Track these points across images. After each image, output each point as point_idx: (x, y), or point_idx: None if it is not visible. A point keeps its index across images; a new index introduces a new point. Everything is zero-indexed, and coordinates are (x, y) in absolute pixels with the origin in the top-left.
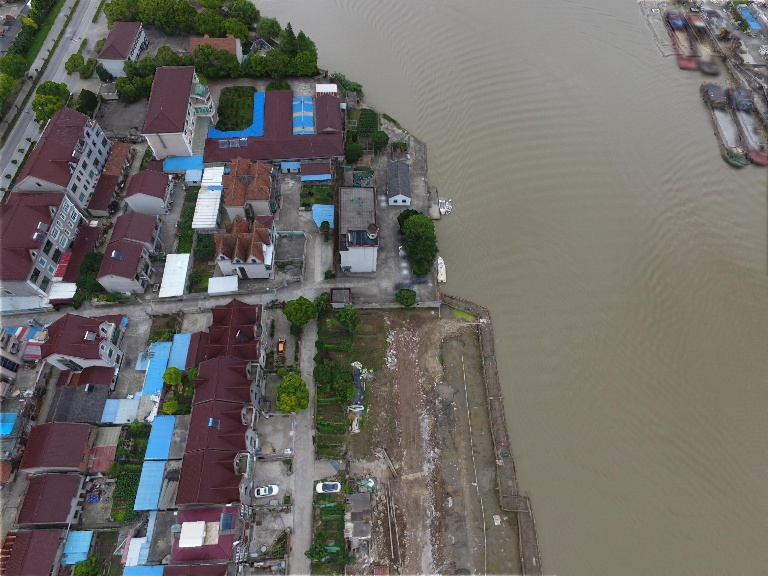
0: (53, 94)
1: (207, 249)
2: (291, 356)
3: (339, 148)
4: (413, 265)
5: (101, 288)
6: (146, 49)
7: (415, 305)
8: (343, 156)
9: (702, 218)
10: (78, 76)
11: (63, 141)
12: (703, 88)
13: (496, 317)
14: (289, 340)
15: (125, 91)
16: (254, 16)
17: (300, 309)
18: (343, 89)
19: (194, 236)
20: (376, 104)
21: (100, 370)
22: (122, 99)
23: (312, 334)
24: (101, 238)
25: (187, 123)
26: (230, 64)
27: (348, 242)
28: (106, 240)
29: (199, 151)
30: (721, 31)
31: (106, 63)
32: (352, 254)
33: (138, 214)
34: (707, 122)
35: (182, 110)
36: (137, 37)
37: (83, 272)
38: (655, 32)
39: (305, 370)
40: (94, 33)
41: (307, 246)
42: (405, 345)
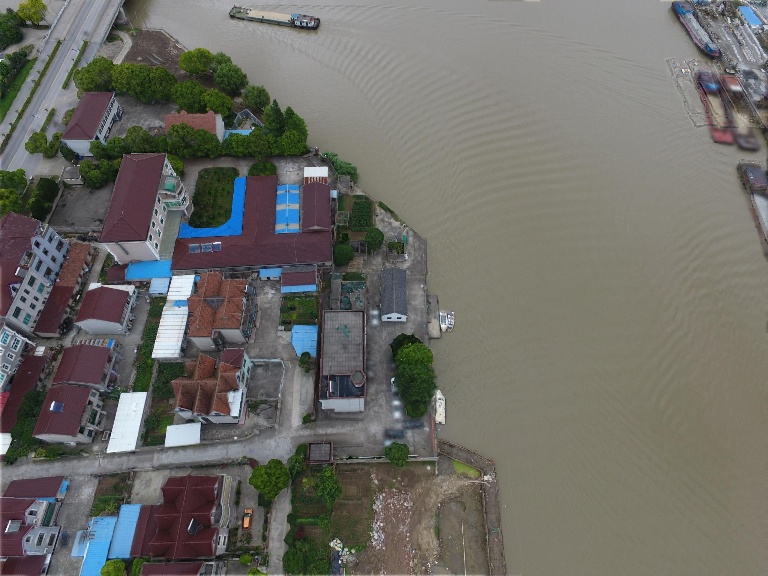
0: (6, 186)
1: (168, 386)
2: (258, 532)
3: (326, 252)
4: (407, 405)
5: (40, 439)
6: (119, 120)
7: (408, 460)
8: (331, 261)
9: (744, 339)
10: (41, 155)
11: (6, 256)
12: (741, 167)
13: (503, 472)
14: (257, 509)
15: (90, 177)
16: (240, 82)
17: (269, 481)
18: (335, 172)
19: (154, 367)
20: (372, 187)
21: (27, 561)
22: (87, 185)
23: (285, 501)
24: (48, 367)
25: (153, 225)
26: (208, 145)
27: (329, 392)
28: (54, 369)
29: (167, 255)
30: (760, 98)
31: (71, 143)
32: (334, 401)
33: (88, 347)
34: (746, 211)
35: (147, 212)
36: (108, 110)
37: (20, 419)
38: (685, 97)
39: (274, 552)
40: (63, 101)
41: (285, 378)
42: (395, 514)
